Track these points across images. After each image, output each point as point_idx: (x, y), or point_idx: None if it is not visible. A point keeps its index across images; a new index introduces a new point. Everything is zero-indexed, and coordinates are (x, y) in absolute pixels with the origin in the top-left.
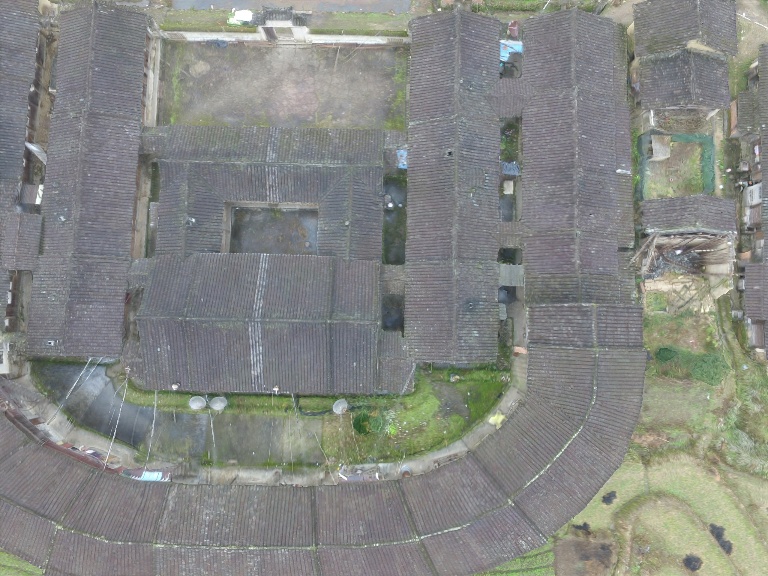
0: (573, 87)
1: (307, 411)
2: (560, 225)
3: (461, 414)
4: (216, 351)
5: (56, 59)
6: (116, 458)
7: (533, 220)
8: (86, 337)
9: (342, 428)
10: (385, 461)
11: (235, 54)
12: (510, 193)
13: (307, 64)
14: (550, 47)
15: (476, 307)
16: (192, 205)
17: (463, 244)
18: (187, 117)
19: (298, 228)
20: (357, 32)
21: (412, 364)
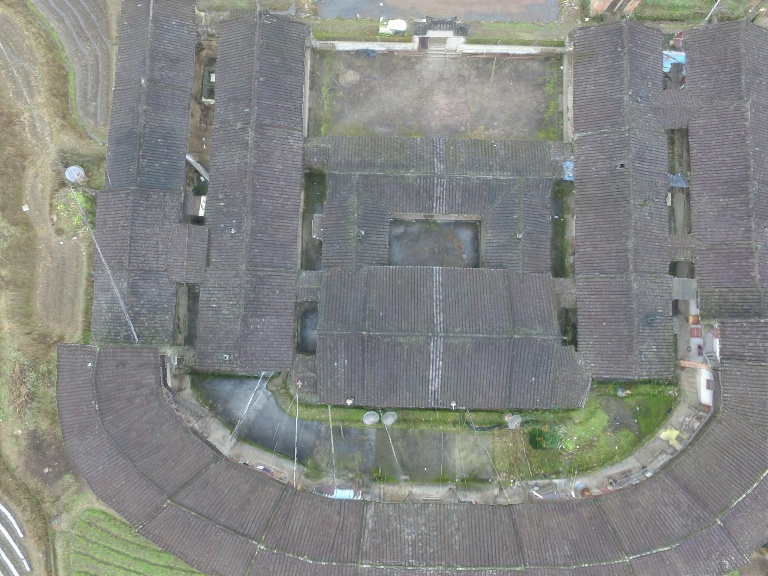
0: (745, 99)
1: (476, 426)
2: (735, 238)
3: (631, 429)
4: (395, 366)
5: (208, 68)
6: (283, 474)
7: (705, 233)
8: (259, 351)
9: (513, 443)
10: (558, 477)
11: (384, 64)
12: (668, 205)
13: (458, 74)
14: (716, 58)
15: (654, 321)
16: (361, 217)
17: (638, 257)
18: (338, 127)
19: (454, 240)
20: (513, 42)
21: (589, 379)
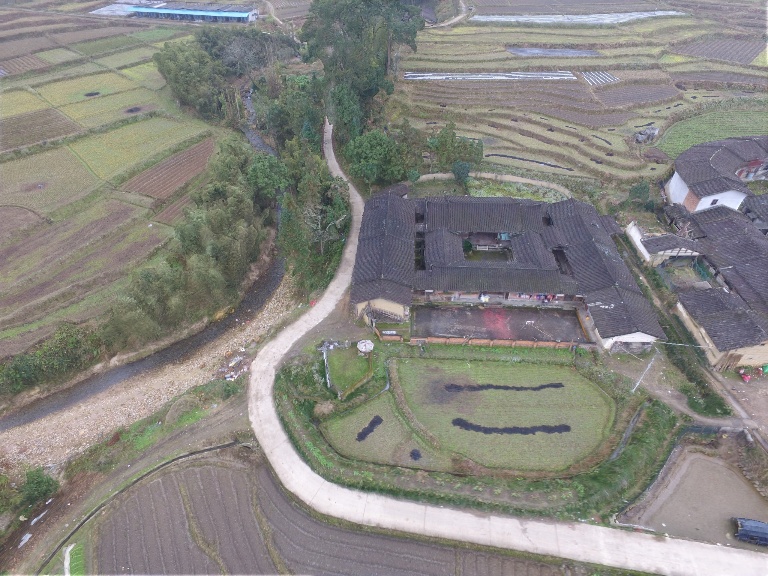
0: None
1: None
2: None
3: None
4: None
5: None
6: None
7: None
8: None
9: None
10: (761, 181)
11: None
12: None
13: None
14: None
15: None
16: None
17: None
18: None
19: None
20: None
21: None
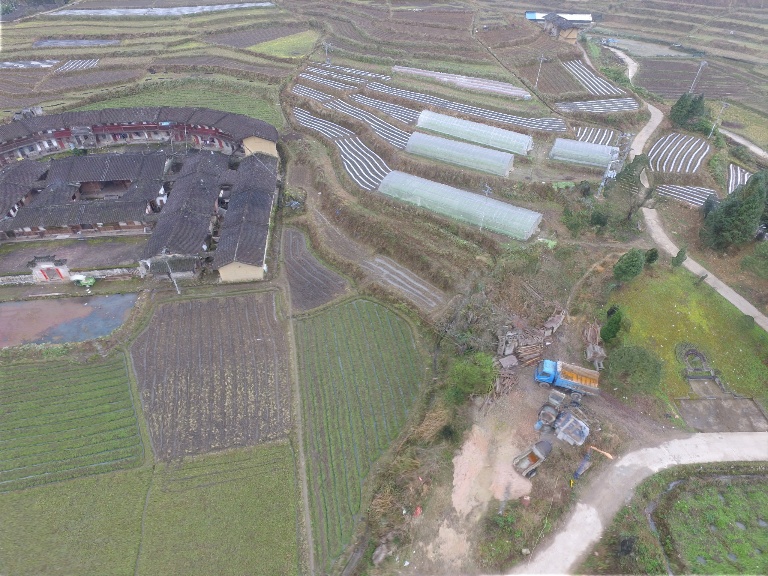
0: None
1: None
2: None
3: None
4: None
5: None
6: None
7: None
8: None
9: None
10: None
11: None
12: None
13: (49, 270)
14: None
15: None
16: None
17: None
18: None
19: None
20: None
21: None
